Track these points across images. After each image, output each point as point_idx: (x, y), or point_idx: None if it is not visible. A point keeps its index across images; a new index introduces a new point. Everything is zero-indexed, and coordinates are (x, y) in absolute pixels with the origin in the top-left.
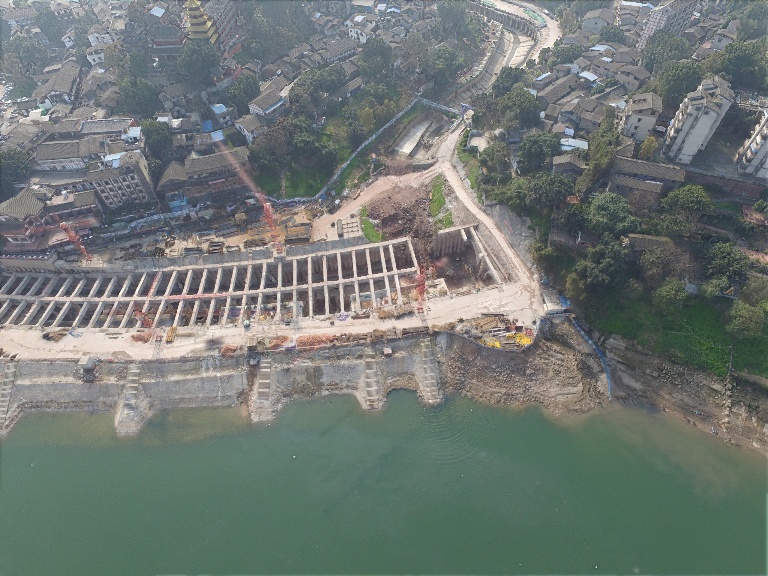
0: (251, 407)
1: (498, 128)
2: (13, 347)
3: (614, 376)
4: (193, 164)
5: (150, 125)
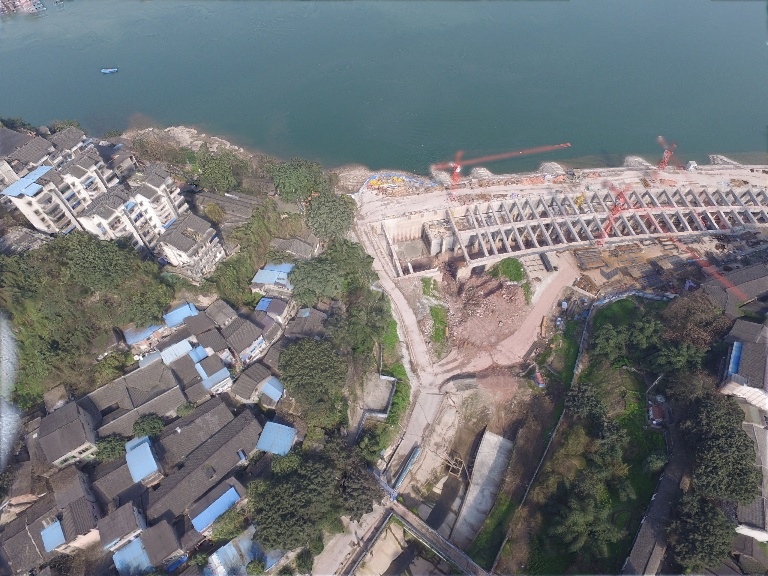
0: None
1: None
2: (762, 176)
3: None
4: (766, 271)
5: None
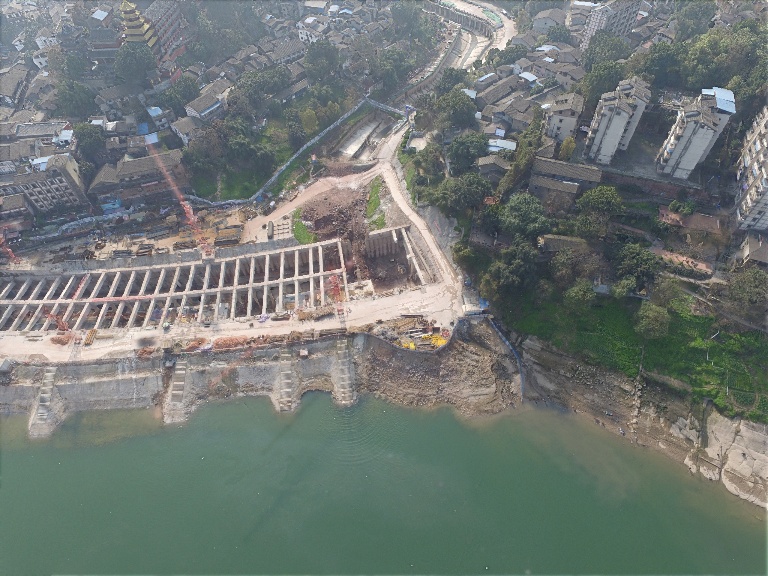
0: (164, 409)
1: (433, 129)
2: None
3: (529, 377)
4: (124, 167)
5: (83, 128)
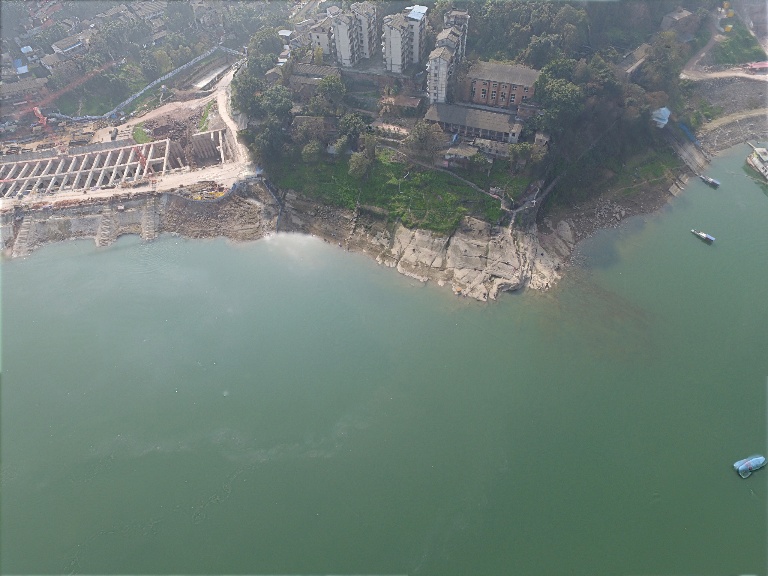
0: (13, 248)
1: None
2: None
3: (287, 218)
4: None
5: None
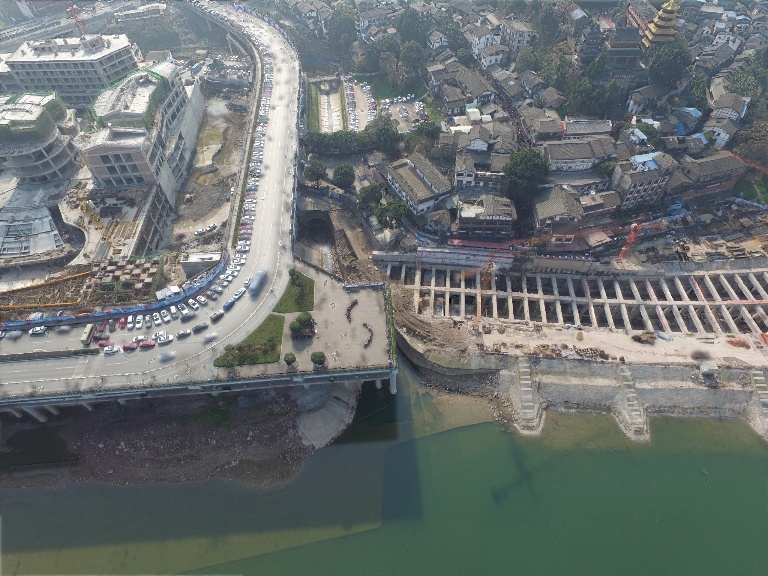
0: None
1: None
2: (612, 349)
3: None
4: (702, 167)
5: (647, 127)
